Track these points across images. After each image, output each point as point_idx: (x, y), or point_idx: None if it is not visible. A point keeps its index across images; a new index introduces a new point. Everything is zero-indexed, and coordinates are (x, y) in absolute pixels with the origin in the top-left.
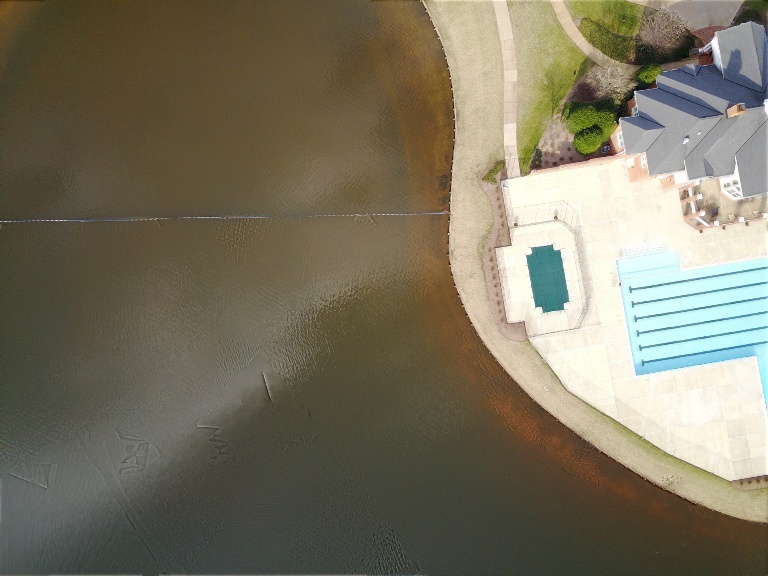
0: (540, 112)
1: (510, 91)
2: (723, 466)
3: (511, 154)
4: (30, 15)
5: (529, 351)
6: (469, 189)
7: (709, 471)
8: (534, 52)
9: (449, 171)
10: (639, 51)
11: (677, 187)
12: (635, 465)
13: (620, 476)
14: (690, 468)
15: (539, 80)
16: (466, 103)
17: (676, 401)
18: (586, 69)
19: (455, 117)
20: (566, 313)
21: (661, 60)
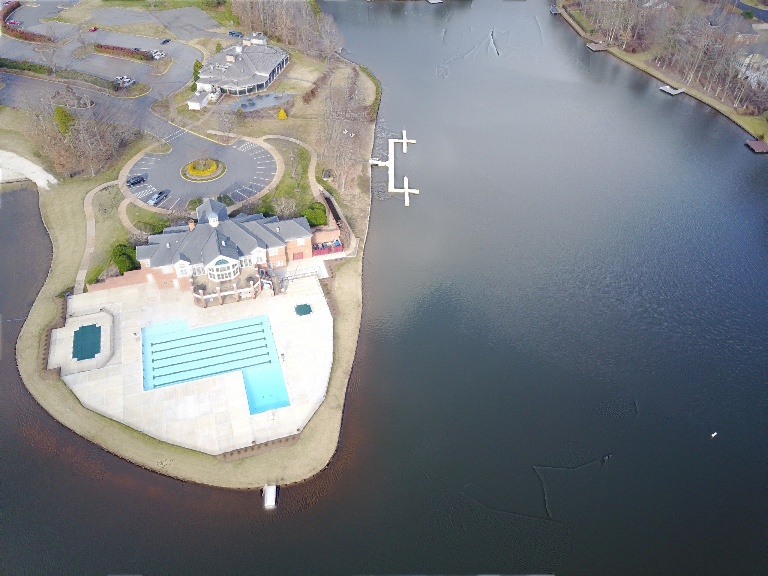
0: (103, 262)
1: (87, 256)
2: (210, 445)
3: (80, 284)
4: None
5: (59, 385)
6: (45, 303)
7: (197, 450)
8: (106, 238)
9: None
10: None
11: None
12: (134, 456)
13: (123, 470)
14: (181, 450)
15: (106, 249)
16: (58, 265)
17: (174, 405)
18: None
19: (49, 273)
20: (96, 359)
21: None
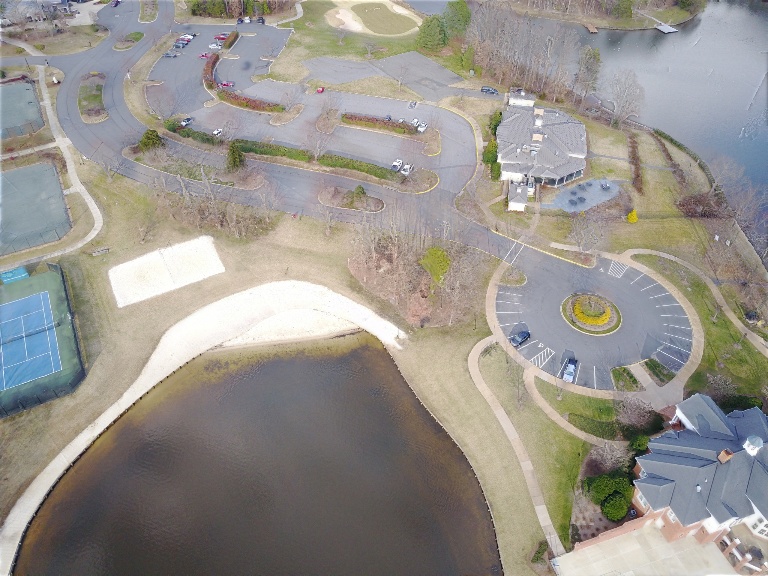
0: (562, 491)
1: (530, 478)
2: None
3: (550, 533)
4: (105, 478)
5: None
6: (522, 574)
7: None
8: (540, 444)
9: (497, 560)
10: (623, 430)
11: (712, 540)
12: None
13: None
14: None
15: (552, 465)
16: (495, 494)
17: None
18: (587, 450)
19: (489, 508)
20: None
21: (644, 434)
